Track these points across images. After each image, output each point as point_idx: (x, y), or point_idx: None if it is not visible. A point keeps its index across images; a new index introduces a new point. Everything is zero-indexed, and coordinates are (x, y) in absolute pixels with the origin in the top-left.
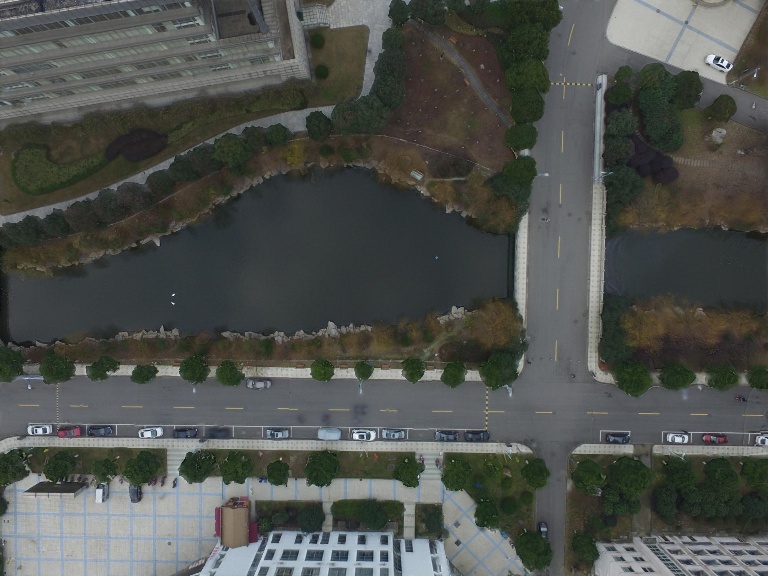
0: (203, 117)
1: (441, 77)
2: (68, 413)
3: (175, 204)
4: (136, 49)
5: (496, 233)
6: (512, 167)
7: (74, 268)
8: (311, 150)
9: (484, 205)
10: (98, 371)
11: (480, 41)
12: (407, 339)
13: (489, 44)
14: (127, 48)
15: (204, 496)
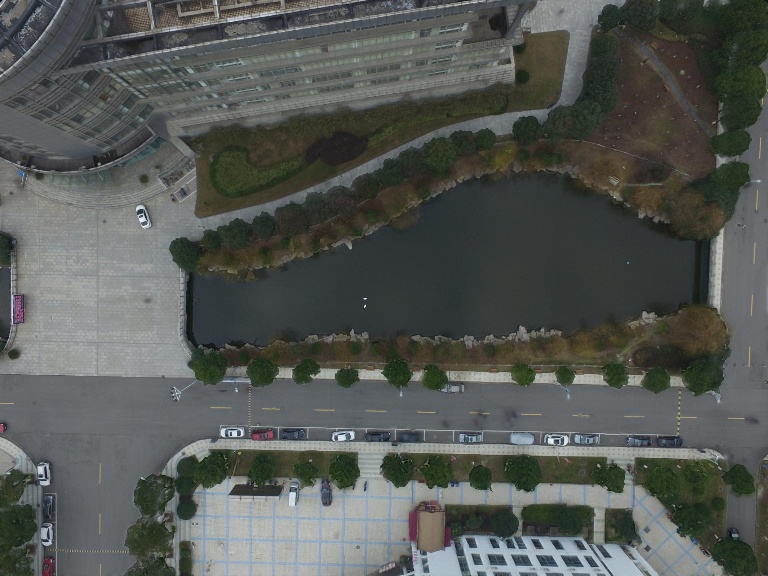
0: (408, 121)
1: (640, 83)
2: (260, 416)
3: (372, 208)
4: (384, 54)
5: (689, 239)
6: (726, 173)
7: (258, 271)
8: (507, 155)
9: (692, 211)
10: (305, 374)
11: (680, 47)
12: (601, 344)
13: (689, 50)
14: (378, 53)
15: (394, 500)
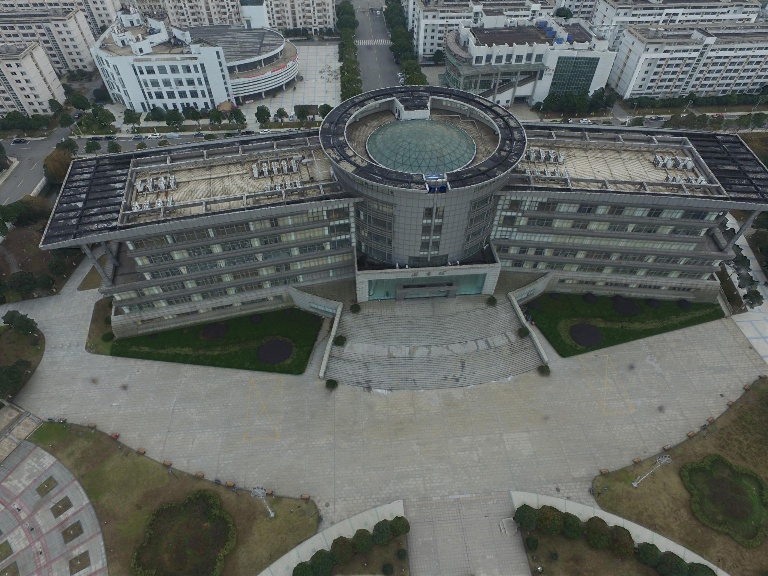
0: None
1: (38, 268)
2: None
3: None
4: None
5: None
6: (9, 209)
7: None
8: None
9: (39, 200)
10: None
11: None
12: None
13: None
14: None
15: None
